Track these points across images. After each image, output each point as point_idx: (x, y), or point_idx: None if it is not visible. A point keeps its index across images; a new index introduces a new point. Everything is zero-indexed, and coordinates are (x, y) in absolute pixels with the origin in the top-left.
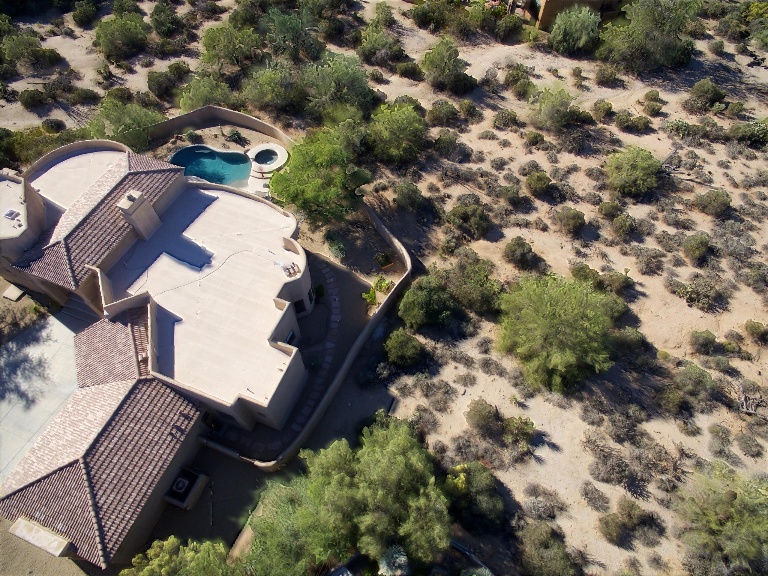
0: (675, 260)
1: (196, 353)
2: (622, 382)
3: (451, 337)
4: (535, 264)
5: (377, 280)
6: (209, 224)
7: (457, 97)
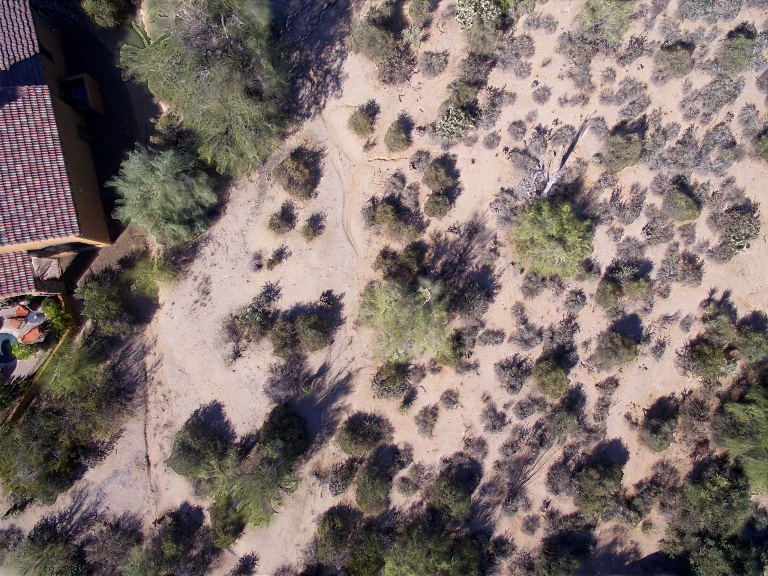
0: (689, 237)
1: None
2: None
3: (766, 541)
4: (667, 411)
5: None
6: None
7: (311, 446)
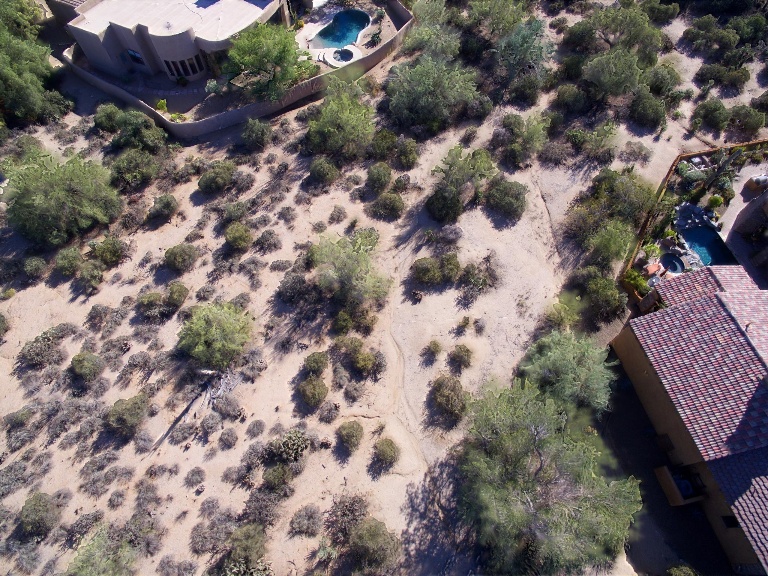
0: None
1: (127, 3)
2: (5, 246)
3: (110, 150)
4: (153, 223)
5: (186, 117)
6: (236, 5)
7: None
